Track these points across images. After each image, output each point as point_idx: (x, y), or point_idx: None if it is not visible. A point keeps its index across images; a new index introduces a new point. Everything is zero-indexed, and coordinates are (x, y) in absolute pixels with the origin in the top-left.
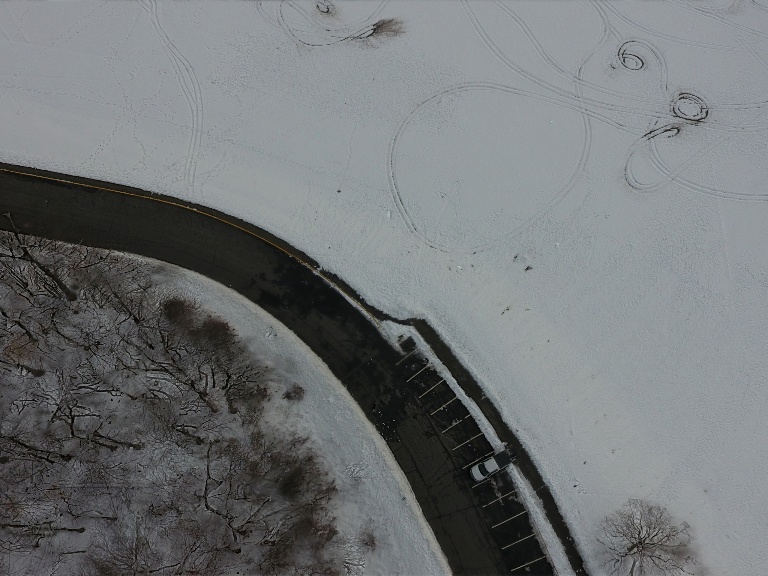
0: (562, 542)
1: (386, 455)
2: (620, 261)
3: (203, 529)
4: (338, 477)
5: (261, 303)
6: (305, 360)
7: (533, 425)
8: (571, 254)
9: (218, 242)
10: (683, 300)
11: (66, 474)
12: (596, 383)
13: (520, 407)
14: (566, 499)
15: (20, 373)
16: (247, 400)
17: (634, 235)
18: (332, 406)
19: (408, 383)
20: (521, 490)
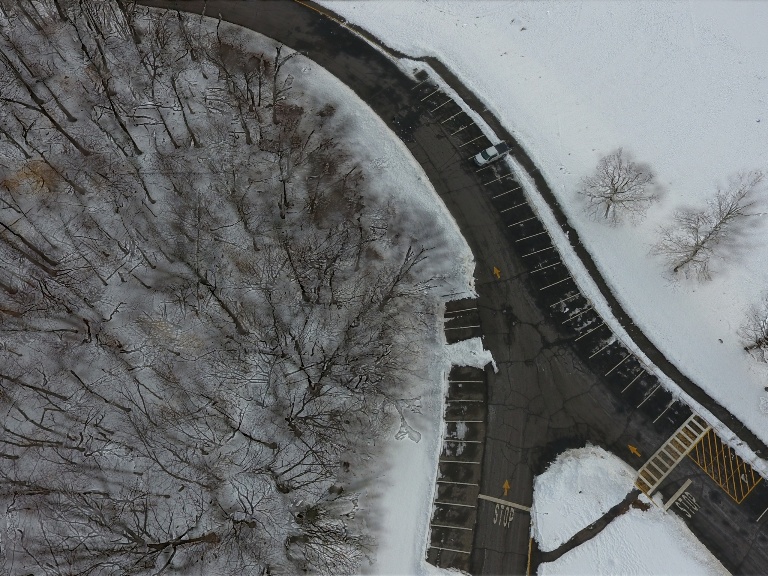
0: (550, 206)
1: (404, 150)
2: (602, 24)
3: (253, 203)
4: (364, 169)
5: (297, 48)
6: (335, 86)
7: (527, 128)
8: (560, 19)
9: (259, 4)
10: (655, 52)
11: (138, 164)
12: (580, 108)
13: (516, 116)
14: (554, 177)
15: (97, 92)
16: (287, 115)
17: (614, 6)
18: (358, 118)
19: (422, 102)
20: (516, 172)
